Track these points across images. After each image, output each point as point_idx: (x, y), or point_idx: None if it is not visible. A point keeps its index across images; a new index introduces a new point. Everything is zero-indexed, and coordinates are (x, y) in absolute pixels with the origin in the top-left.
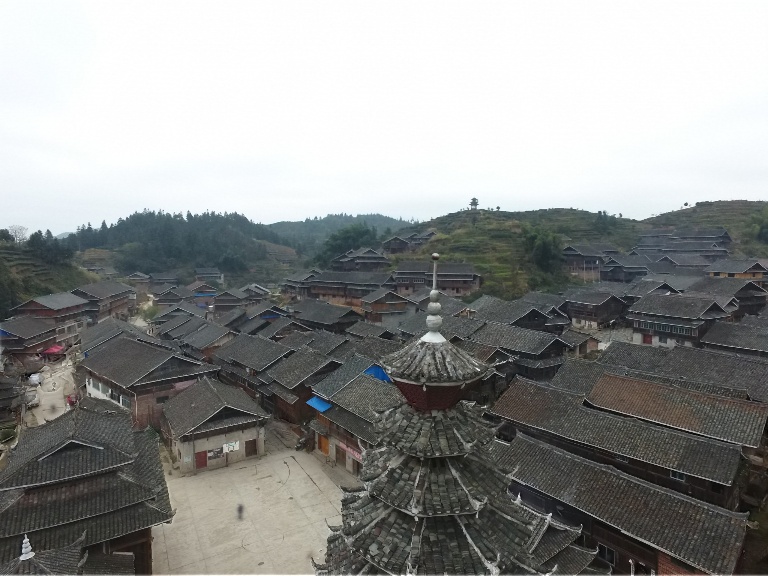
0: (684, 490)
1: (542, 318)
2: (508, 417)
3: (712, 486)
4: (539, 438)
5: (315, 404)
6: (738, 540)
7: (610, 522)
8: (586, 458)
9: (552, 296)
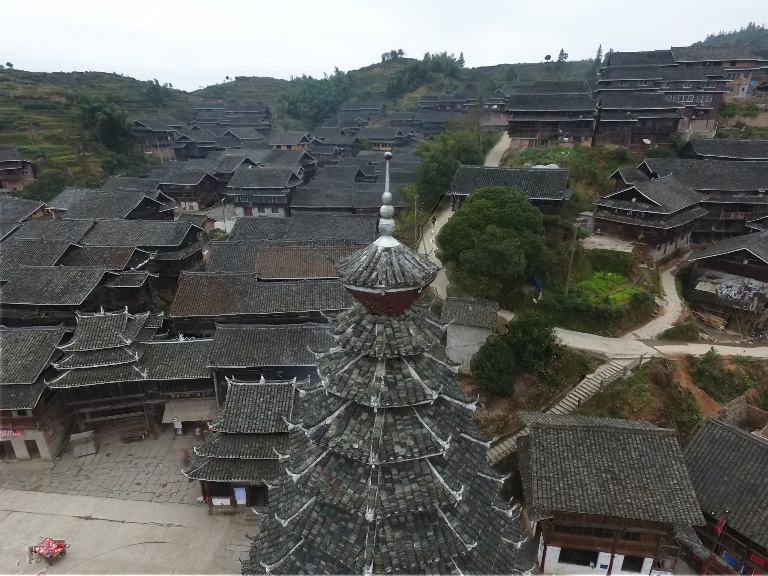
0: None
1: (154, 206)
2: (193, 315)
3: None
4: None
5: None
6: None
7: None
8: (288, 324)
9: (141, 180)
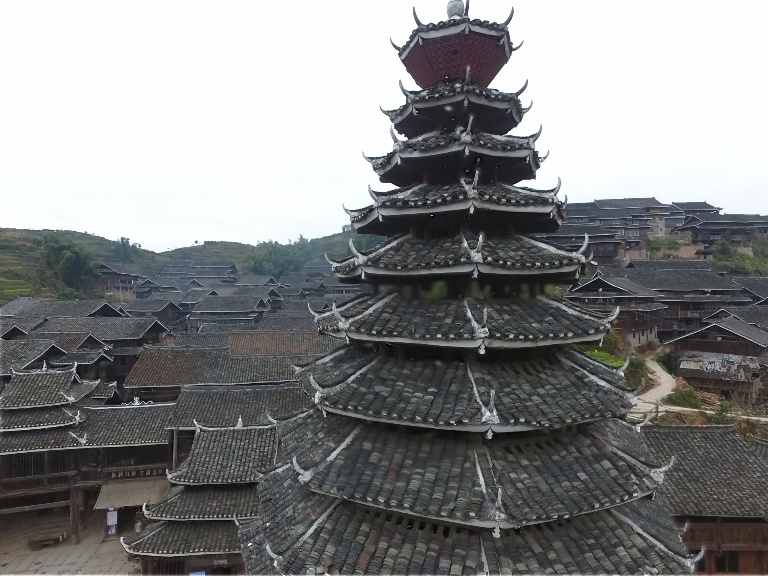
0: None
1: None
2: (152, 385)
3: None
4: None
5: None
6: None
7: None
8: None
9: None
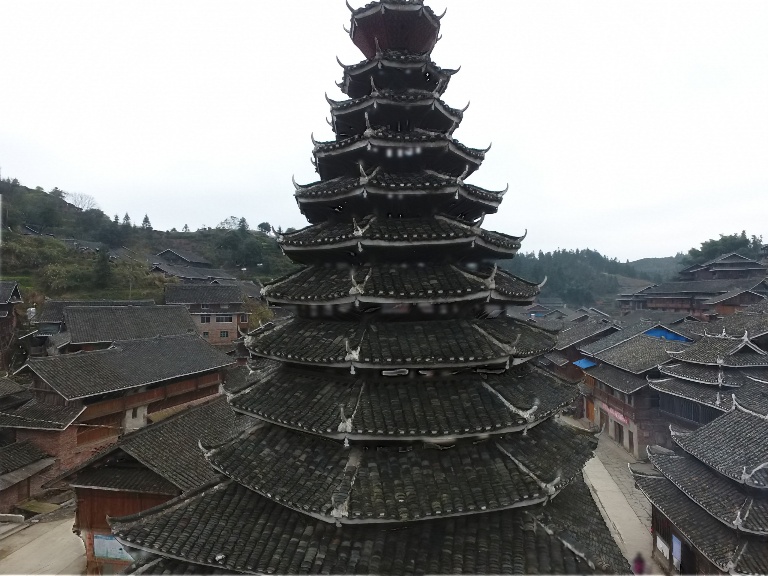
0: None
1: None
2: None
3: None
4: None
5: (581, 364)
6: None
7: None
8: None
9: None
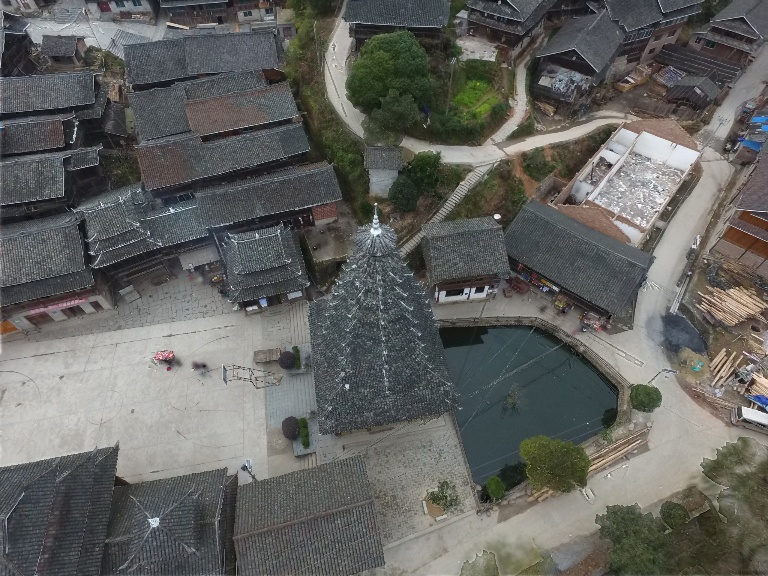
0: (290, 164)
1: (14, 38)
2: (165, 185)
3: (302, 154)
4: (195, 185)
5: None
6: (335, 179)
7: (289, 209)
8: (250, 183)
9: None
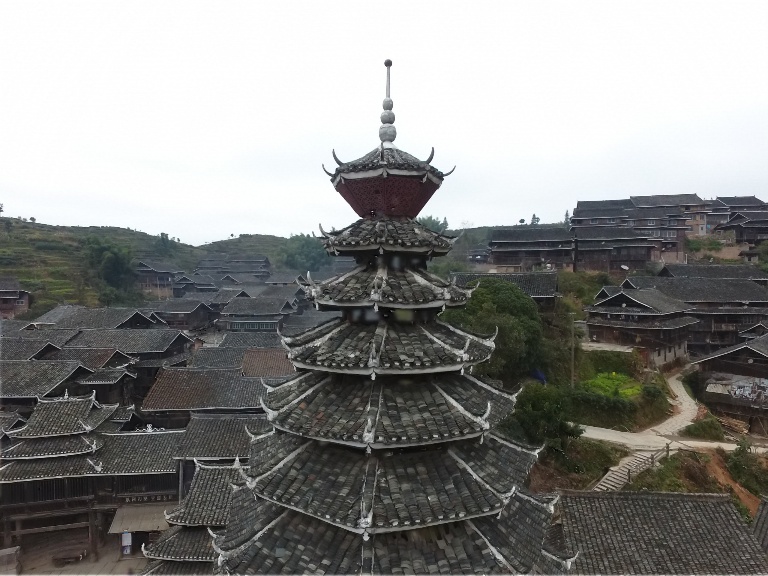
0: None
1: (144, 323)
2: (167, 408)
3: None
4: None
5: None
6: None
7: None
8: None
9: None
